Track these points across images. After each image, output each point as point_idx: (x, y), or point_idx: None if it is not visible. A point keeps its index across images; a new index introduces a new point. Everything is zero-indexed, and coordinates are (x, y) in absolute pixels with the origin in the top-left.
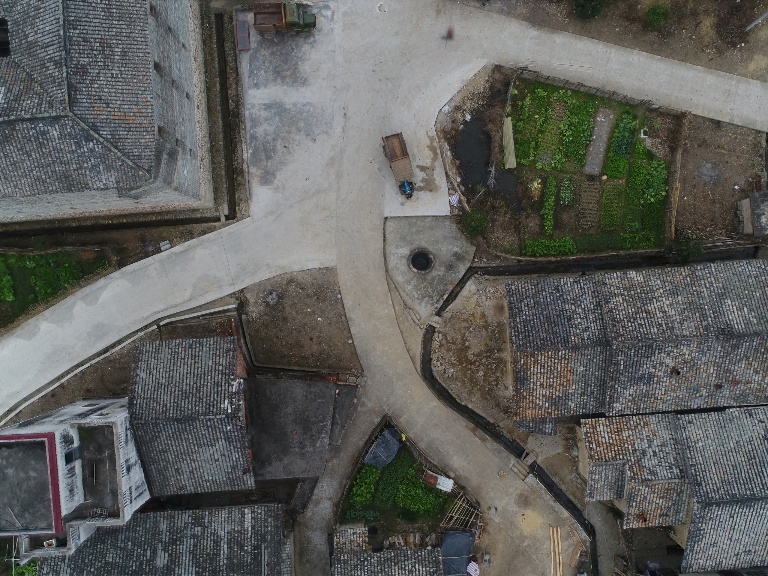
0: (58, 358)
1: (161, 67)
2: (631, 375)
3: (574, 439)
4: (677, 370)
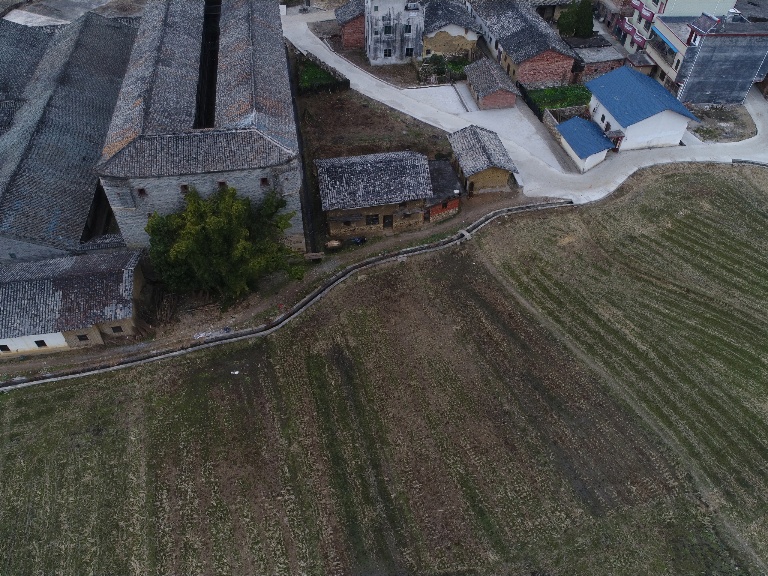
0: None
1: None
2: None
3: None
4: None
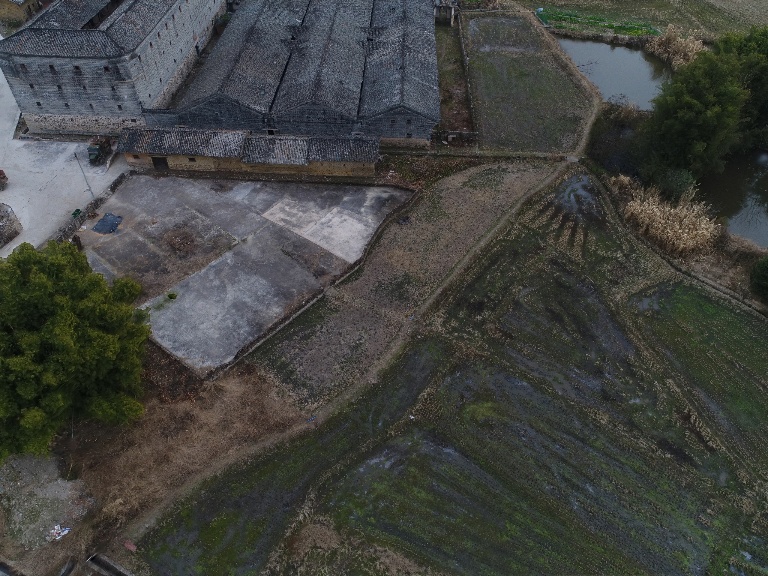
0: None
1: (57, 74)
2: None
3: None
4: None
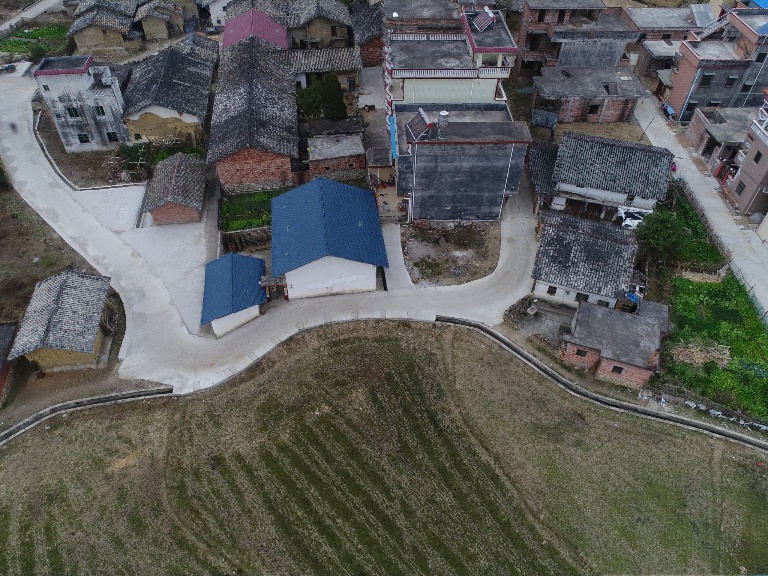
0: (36, 159)
1: None
2: (114, 6)
3: (152, 39)
4: None
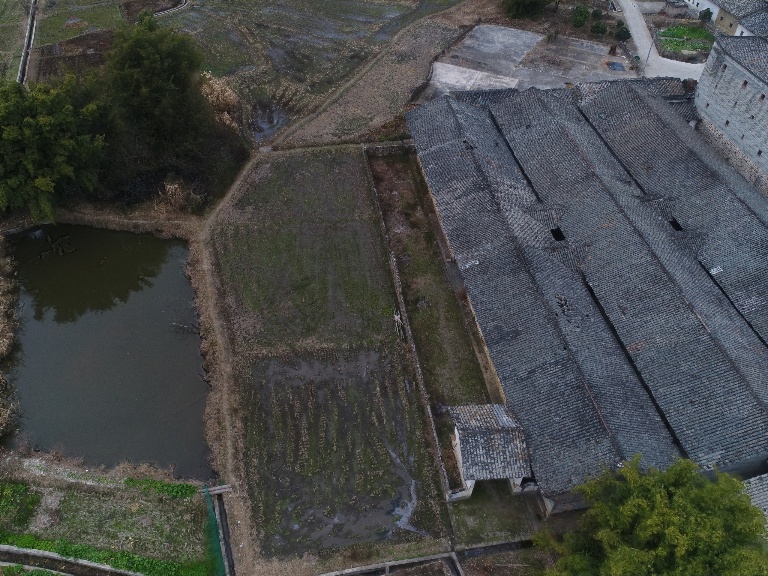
0: None
1: None
2: None
3: None
4: (762, 0)
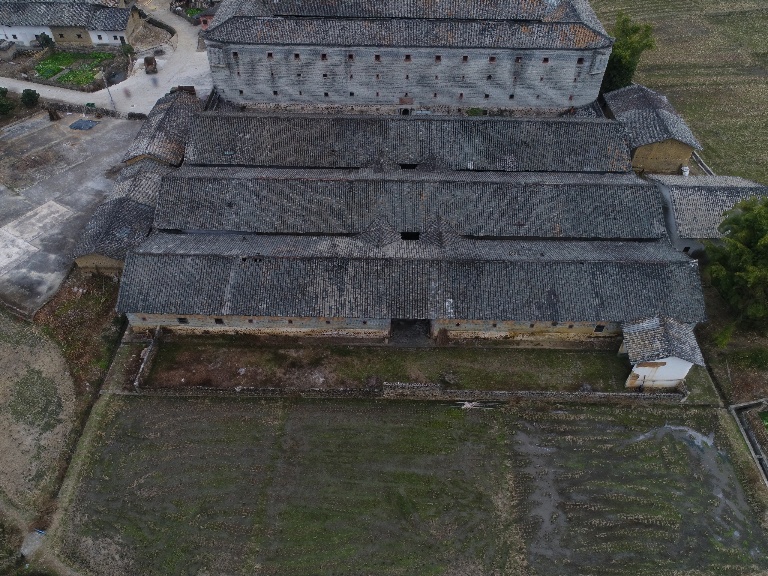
0: None
1: None
2: None
3: None
4: None
